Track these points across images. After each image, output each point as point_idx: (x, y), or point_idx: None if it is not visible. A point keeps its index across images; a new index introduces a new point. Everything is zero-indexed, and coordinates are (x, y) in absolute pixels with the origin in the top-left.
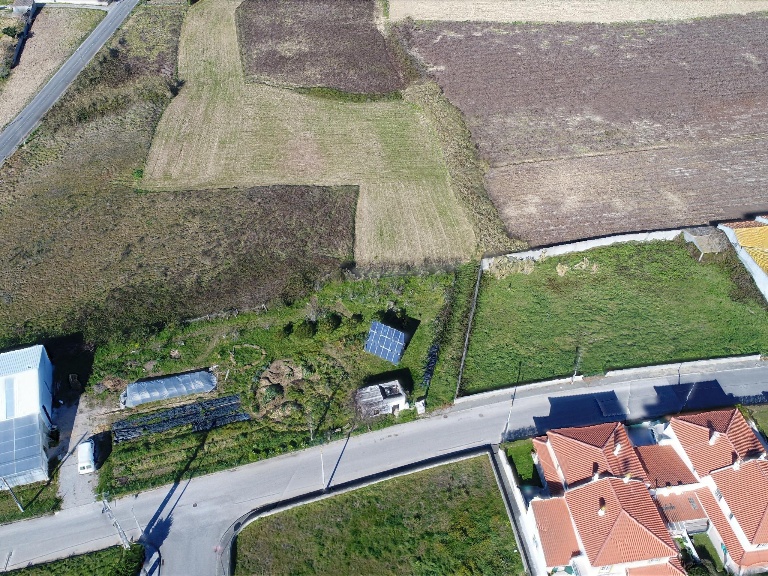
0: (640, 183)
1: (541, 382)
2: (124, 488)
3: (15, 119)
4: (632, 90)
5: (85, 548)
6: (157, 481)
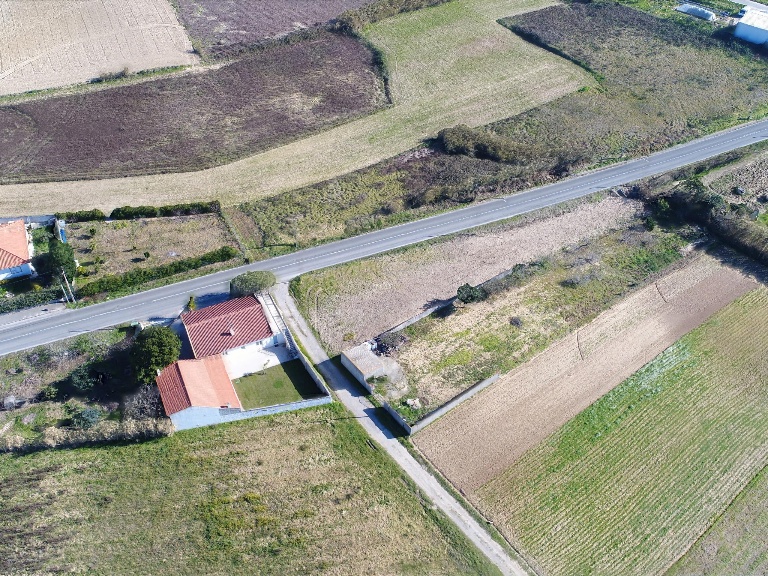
0: None
1: None
2: (739, 4)
3: (600, 191)
4: None
5: (762, 4)
6: (727, 1)
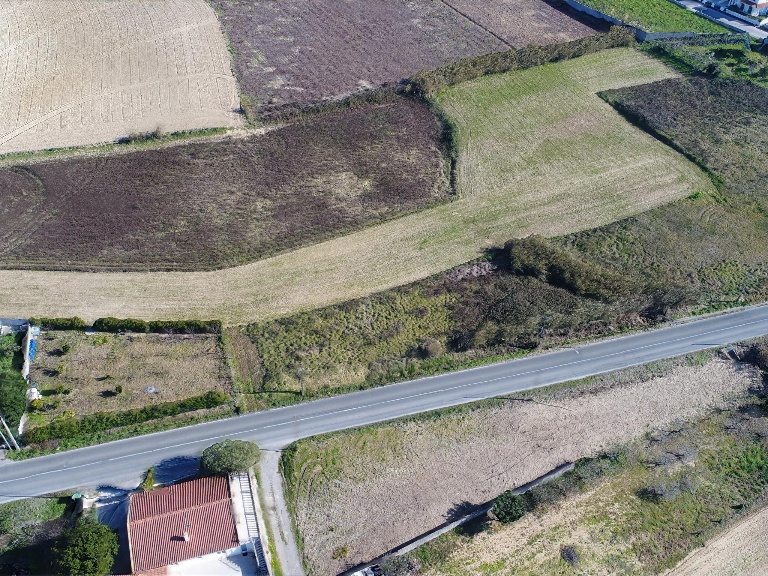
0: (498, 8)
1: (713, 18)
2: None
3: (704, 349)
4: (361, 8)
5: None
6: None
